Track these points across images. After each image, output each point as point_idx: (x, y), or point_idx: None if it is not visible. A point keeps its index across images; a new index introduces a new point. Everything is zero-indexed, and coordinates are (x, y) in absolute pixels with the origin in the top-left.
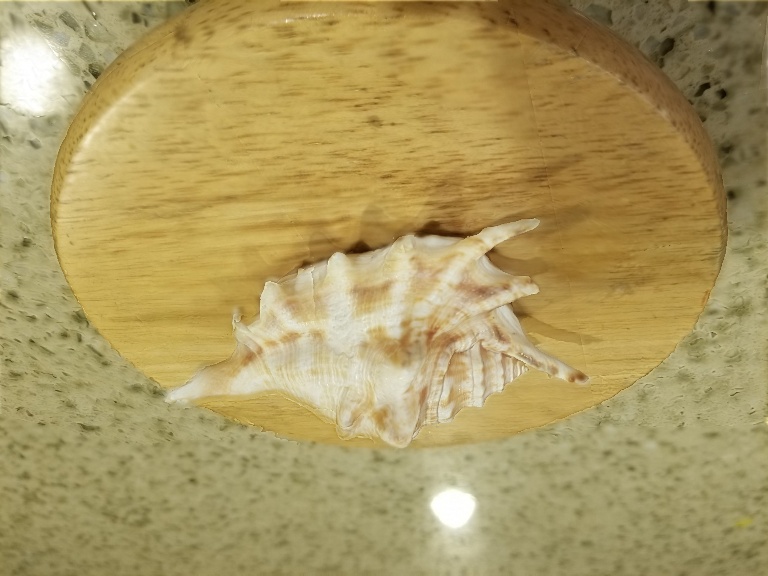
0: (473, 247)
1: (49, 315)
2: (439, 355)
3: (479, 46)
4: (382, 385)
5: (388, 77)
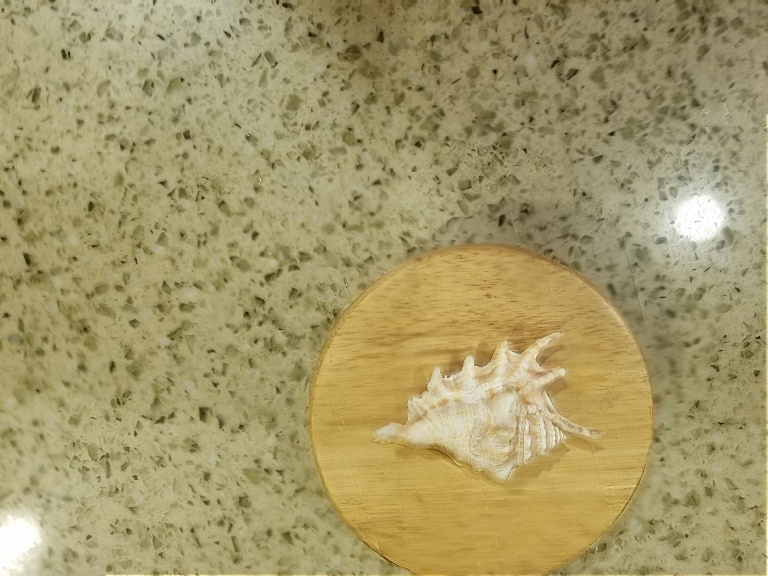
0: (533, 348)
1: (221, 500)
2: (522, 405)
3: (529, 265)
4: (498, 405)
5: (495, 276)
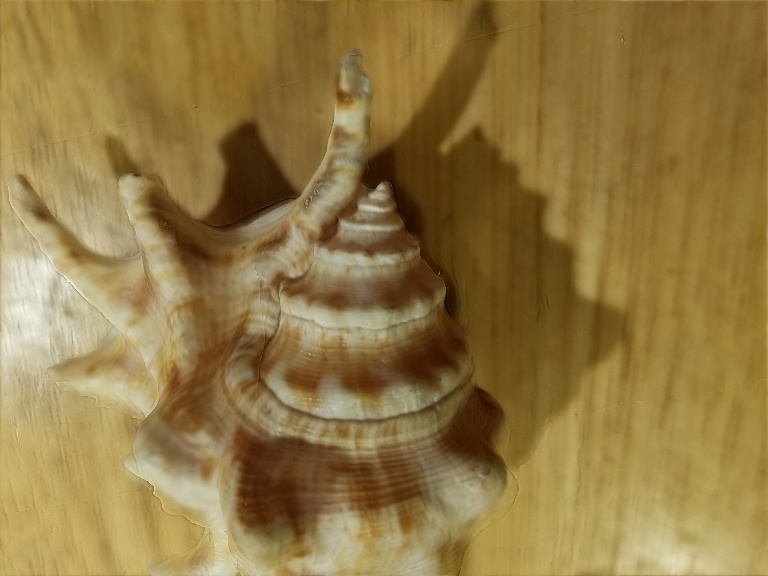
0: (68, 278)
1: None
2: (224, 377)
3: None
4: None
5: None
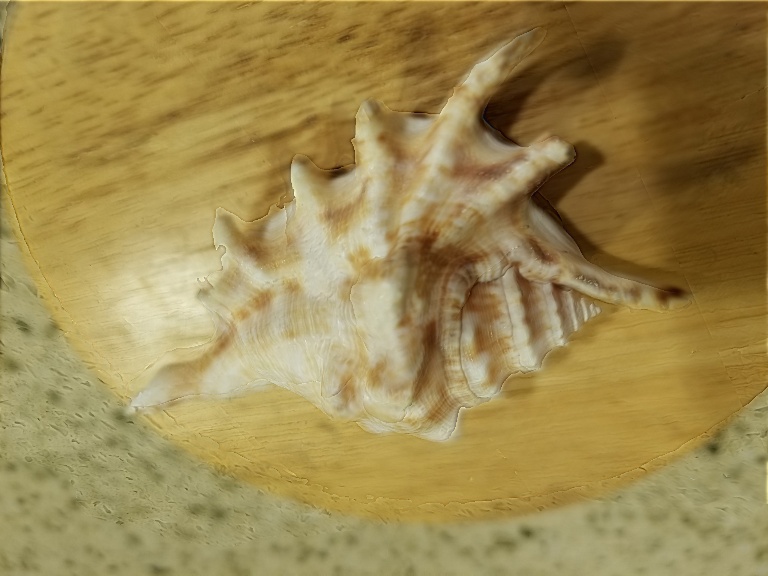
0: (463, 98)
1: (101, 379)
2: (448, 277)
3: None
4: (362, 315)
5: None
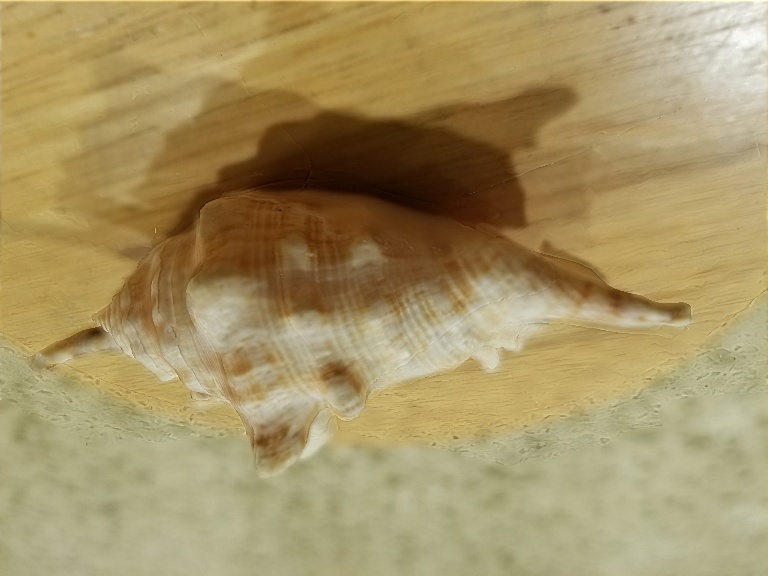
0: None
1: None
2: None
3: None
4: None
5: (399, 412)
